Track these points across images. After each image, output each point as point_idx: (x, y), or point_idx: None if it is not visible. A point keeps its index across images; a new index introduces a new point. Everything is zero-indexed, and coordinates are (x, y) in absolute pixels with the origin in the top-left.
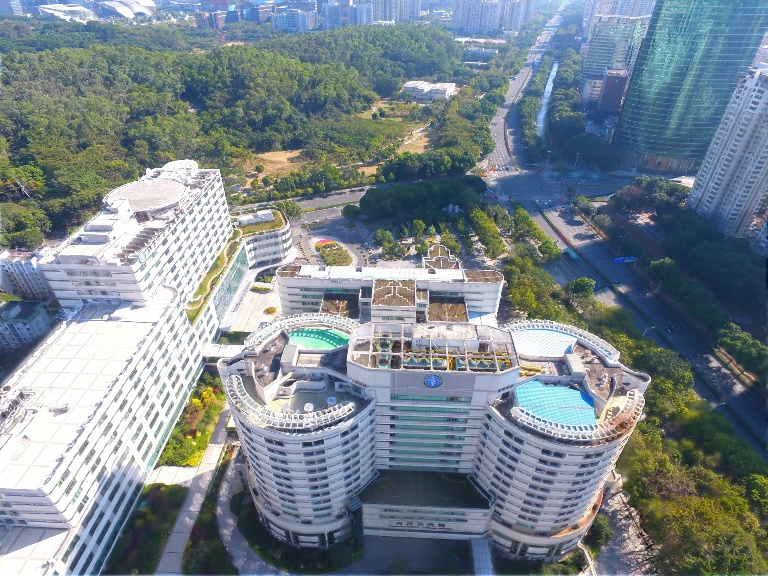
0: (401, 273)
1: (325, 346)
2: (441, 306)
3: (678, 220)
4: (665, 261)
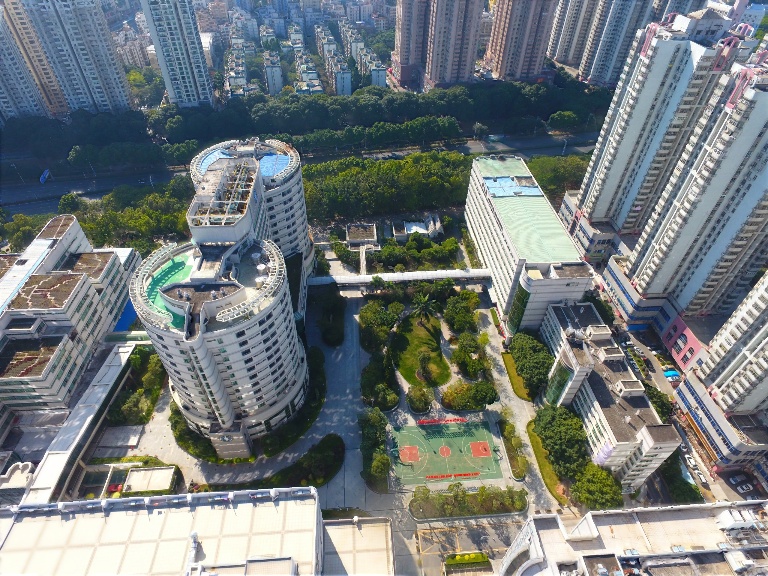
0: (7, 287)
1: (178, 276)
2: (77, 270)
3: (17, 130)
4: (77, 149)
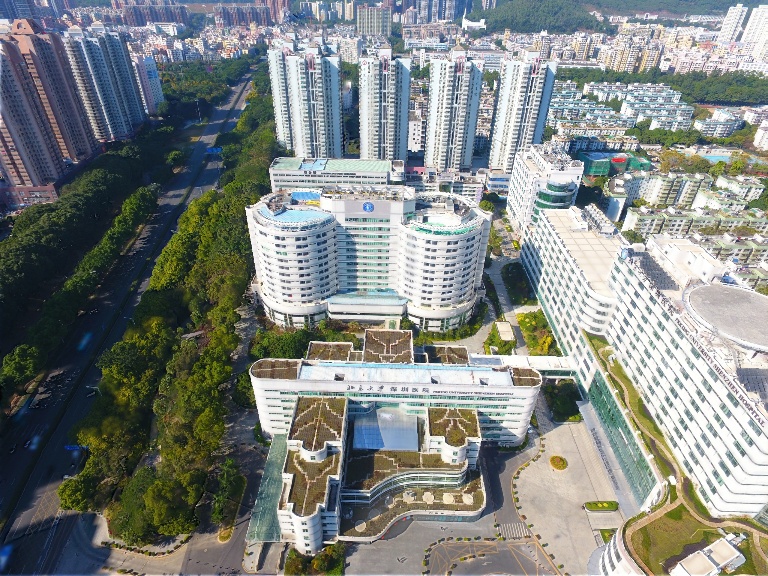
0: (380, 374)
1: None
2: None
3: None
4: None
